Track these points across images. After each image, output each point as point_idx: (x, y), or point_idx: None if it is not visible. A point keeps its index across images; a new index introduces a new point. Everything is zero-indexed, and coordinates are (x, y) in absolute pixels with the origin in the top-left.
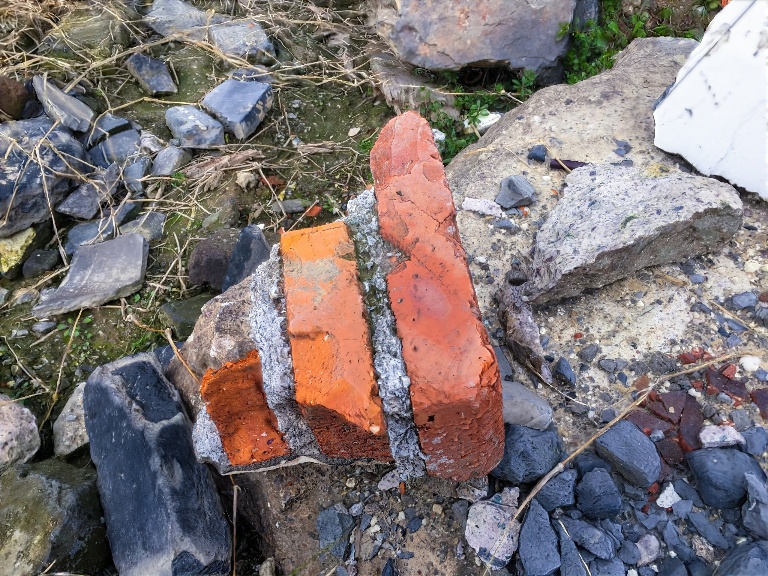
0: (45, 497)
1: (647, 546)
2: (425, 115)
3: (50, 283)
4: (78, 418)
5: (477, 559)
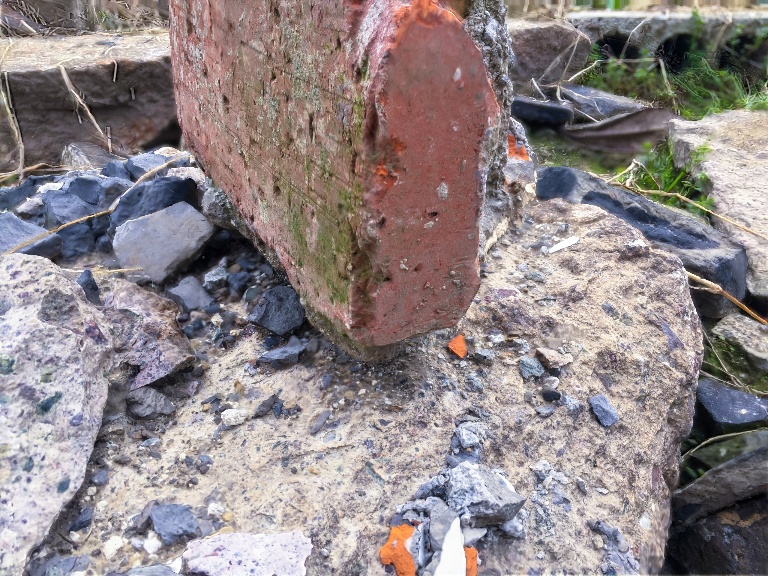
0: None
1: (31, 203)
2: None
3: None
4: (759, 330)
5: None
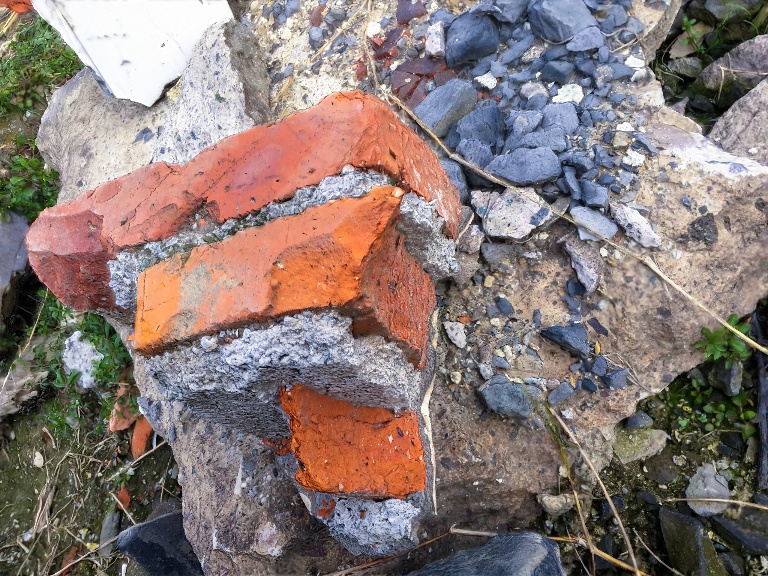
0: None
1: (531, 90)
2: (46, 368)
3: None
4: None
5: (542, 236)
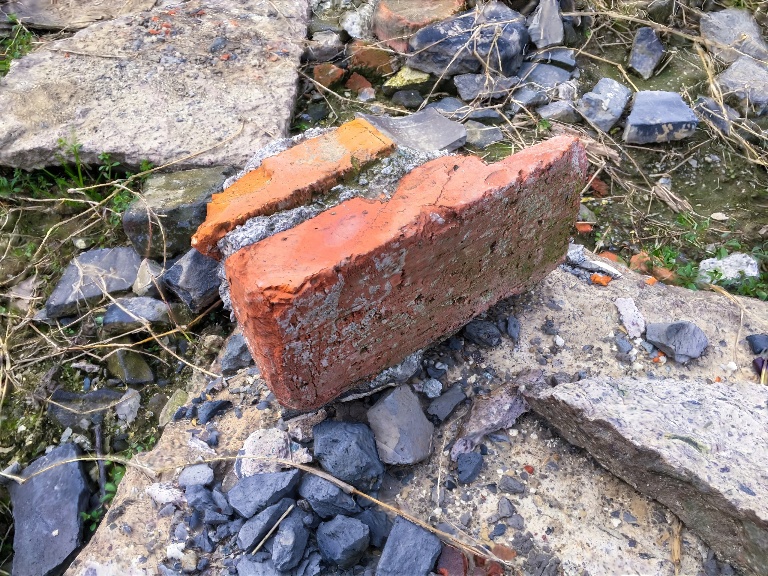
0: (209, 189)
1: None
2: None
3: (396, 114)
4: None
5: None
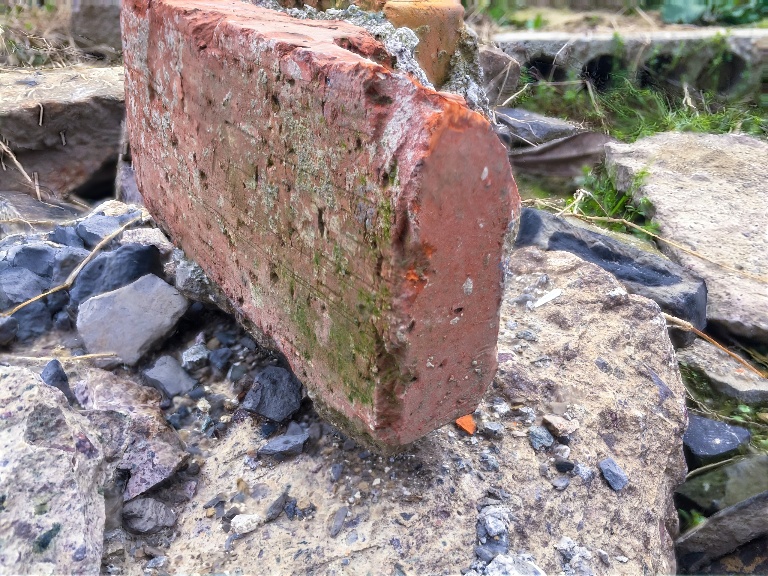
0: None
1: None
2: None
3: None
4: (717, 354)
5: None
